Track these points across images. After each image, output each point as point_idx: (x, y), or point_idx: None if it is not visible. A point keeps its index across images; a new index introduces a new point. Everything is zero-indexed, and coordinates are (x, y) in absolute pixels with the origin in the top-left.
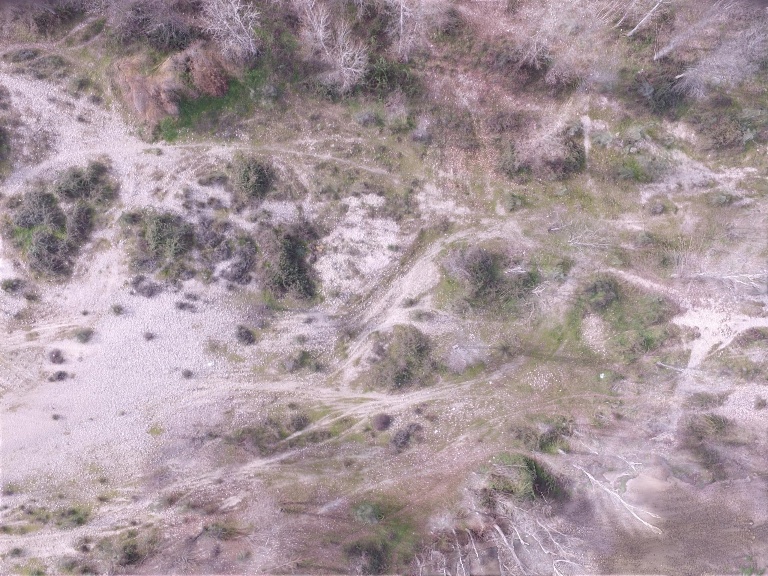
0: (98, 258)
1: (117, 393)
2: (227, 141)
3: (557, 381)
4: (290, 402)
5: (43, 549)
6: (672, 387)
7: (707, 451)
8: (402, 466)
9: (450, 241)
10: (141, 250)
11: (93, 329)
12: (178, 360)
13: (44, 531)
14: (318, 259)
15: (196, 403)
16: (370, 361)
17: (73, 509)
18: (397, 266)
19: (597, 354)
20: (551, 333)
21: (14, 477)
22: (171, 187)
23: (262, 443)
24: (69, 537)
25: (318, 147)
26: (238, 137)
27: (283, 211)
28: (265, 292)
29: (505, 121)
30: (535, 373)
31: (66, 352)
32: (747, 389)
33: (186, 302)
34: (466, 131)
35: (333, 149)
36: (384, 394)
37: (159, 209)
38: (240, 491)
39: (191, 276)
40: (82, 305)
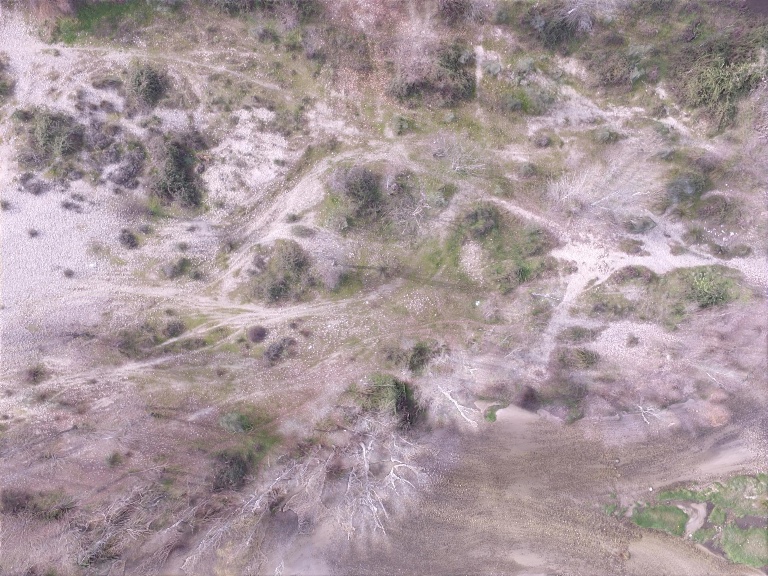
0: None
1: None
2: (124, 47)
3: (433, 305)
4: (168, 308)
5: None
6: (547, 319)
7: (575, 384)
8: (274, 379)
9: (337, 160)
10: (31, 147)
11: None
12: (61, 259)
13: None
14: (206, 169)
15: (76, 302)
16: (250, 273)
17: None
18: (283, 181)
19: (474, 281)
20: (430, 257)
21: None
22: (66, 88)
23: (138, 346)
24: None
25: (213, 59)
26: (135, 44)
27: (174, 119)
28: (152, 198)
29: (398, 45)
30: (412, 296)
31: None
32: (621, 326)
33: (72, 202)
34: (359, 52)
35: (227, 62)
36: (261, 307)
37: (52, 108)
38: (113, 393)
39: (79, 176)
40: None
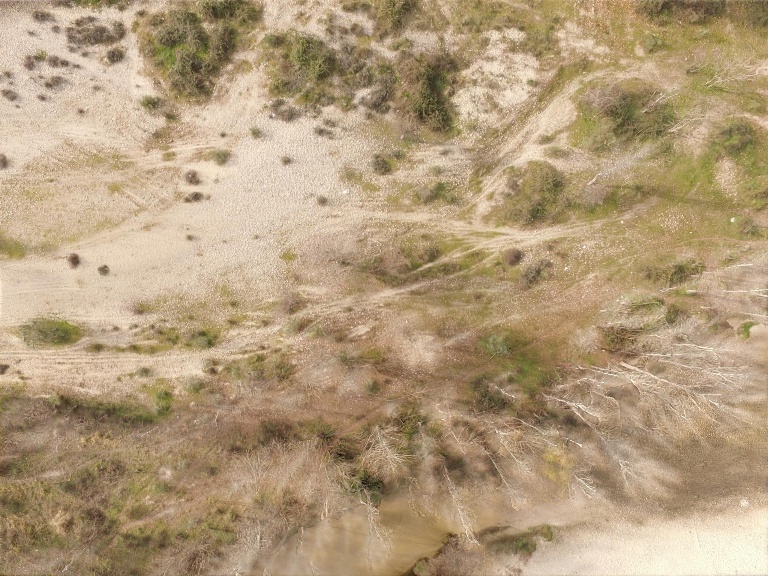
0: (239, 80)
1: (252, 216)
2: None
3: (688, 223)
4: (423, 233)
5: (171, 370)
6: None
7: None
8: (531, 302)
9: (588, 79)
10: (283, 72)
11: (230, 151)
12: (314, 186)
13: (173, 352)
14: (456, 92)
15: (329, 230)
16: (504, 195)
17: (203, 331)
18: (535, 102)
19: (728, 198)
20: (684, 175)
21: (145, 296)
22: (314, 12)
23: (393, 273)
24: (197, 359)
25: None
26: None
27: (425, 41)
28: (402, 123)
29: None
30: (666, 214)
31: (202, 174)
32: None
33: (324, 128)
34: None
35: None
36: (516, 229)
37: (302, 33)
38: (369, 320)
39: (331, 102)
40: (221, 127)
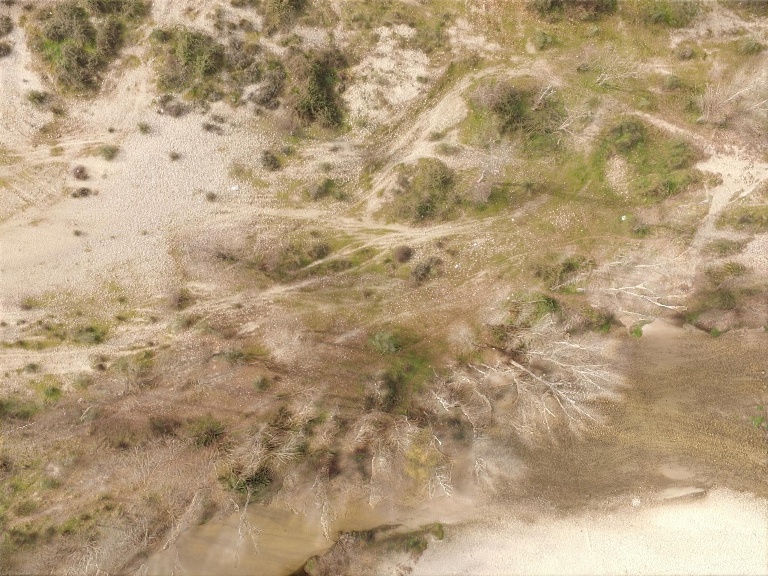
0: (127, 75)
1: (140, 212)
2: None
3: (579, 221)
4: (312, 230)
5: (59, 366)
6: (692, 233)
7: (724, 295)
8: (421, 299)
9: (479, 76)
10: (171, 68)
11: (119, 147)
12: (202, 182)
13: (61, 348)
14: (347, 89)
15: (219, 226)
16: (394, 192)
17: (91, 327)
18: (425, 99)
19: (620, 196)
20: (575, 173)
21: (33, 292)
22: (203, 7)
23: (283, 269)
24: (86, 355)
25: None
26: None
27: (314, 37)
28: (292, 119)
29: None
30: (557, 212)
31: (90, 169)
32: (766, 238)
33: (213, 124)
34: None
35: None
36: (406, 226)
37: (190, 29)
38: (259, 317)
39: (219, 97)
40: (109, 122)
